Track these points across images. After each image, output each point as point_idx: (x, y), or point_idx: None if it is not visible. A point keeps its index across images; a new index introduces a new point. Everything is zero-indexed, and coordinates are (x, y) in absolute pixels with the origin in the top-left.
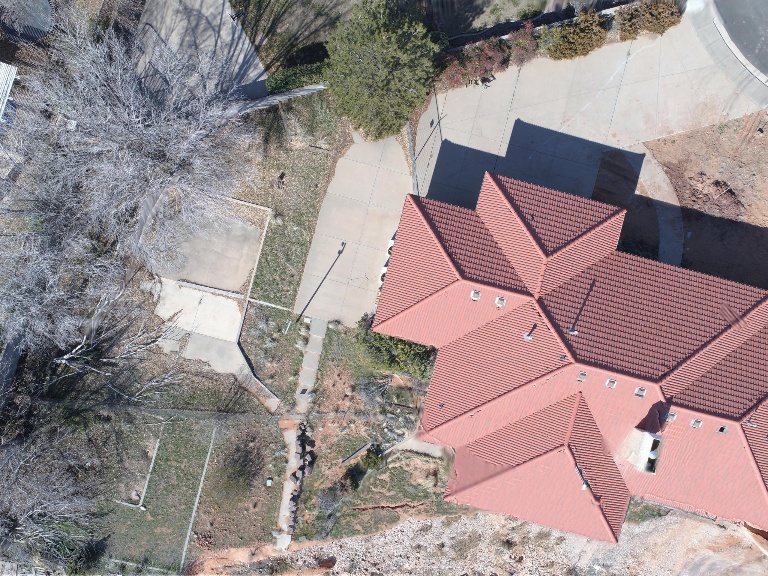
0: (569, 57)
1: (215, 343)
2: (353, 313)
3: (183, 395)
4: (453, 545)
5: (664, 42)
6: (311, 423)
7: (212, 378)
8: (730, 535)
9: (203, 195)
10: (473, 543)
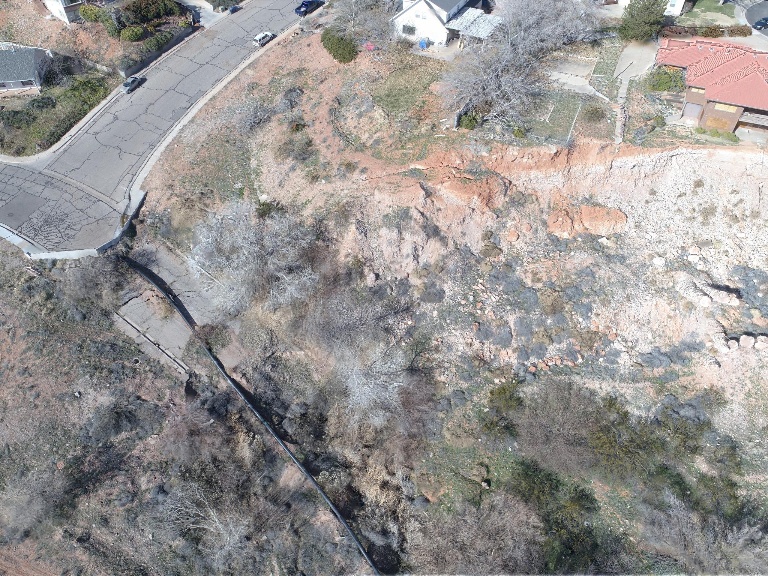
0: (711, 36)
1: (577, 86)
2: (643, 69)
3: (564, 95)
4: None
5: (747, 38)
6: None
7: (577, 93)
8: None
9: (567, 56)
10: (712, 210)
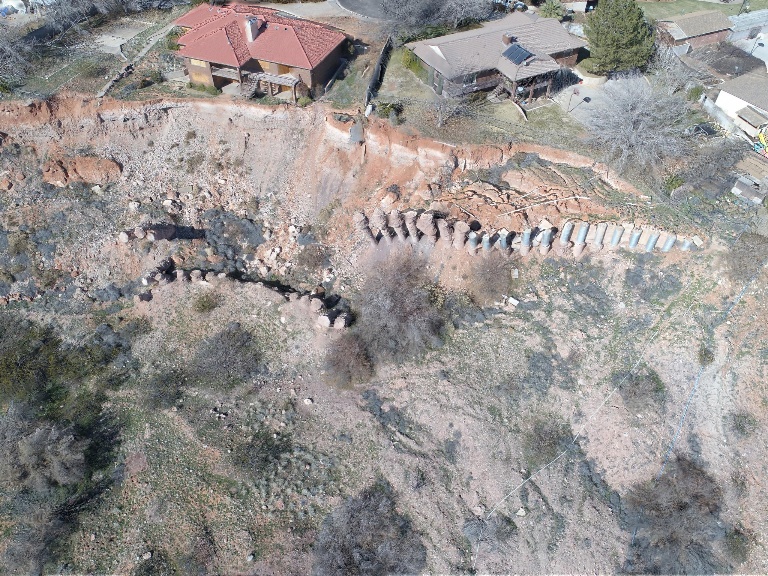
0: (280, 2)
1: None
2: None
3: None
4: None
5: (316, 4)
6: (136, 65)
7: None
8: (329, 147)
9: None
10: (199, 159)
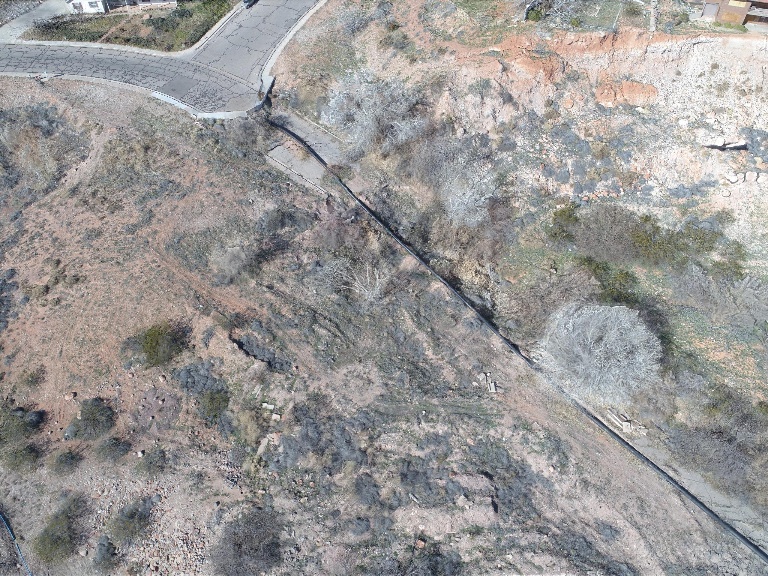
0: None
1: None
2: None
3: (608, 0)
4: (716, 86)
5: None
6: None
7: None
8: None
9: None
10: (726, 86)
